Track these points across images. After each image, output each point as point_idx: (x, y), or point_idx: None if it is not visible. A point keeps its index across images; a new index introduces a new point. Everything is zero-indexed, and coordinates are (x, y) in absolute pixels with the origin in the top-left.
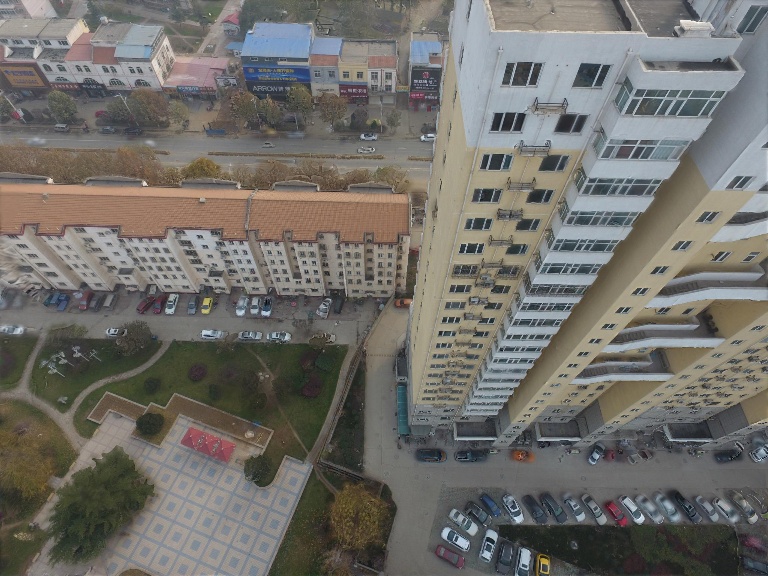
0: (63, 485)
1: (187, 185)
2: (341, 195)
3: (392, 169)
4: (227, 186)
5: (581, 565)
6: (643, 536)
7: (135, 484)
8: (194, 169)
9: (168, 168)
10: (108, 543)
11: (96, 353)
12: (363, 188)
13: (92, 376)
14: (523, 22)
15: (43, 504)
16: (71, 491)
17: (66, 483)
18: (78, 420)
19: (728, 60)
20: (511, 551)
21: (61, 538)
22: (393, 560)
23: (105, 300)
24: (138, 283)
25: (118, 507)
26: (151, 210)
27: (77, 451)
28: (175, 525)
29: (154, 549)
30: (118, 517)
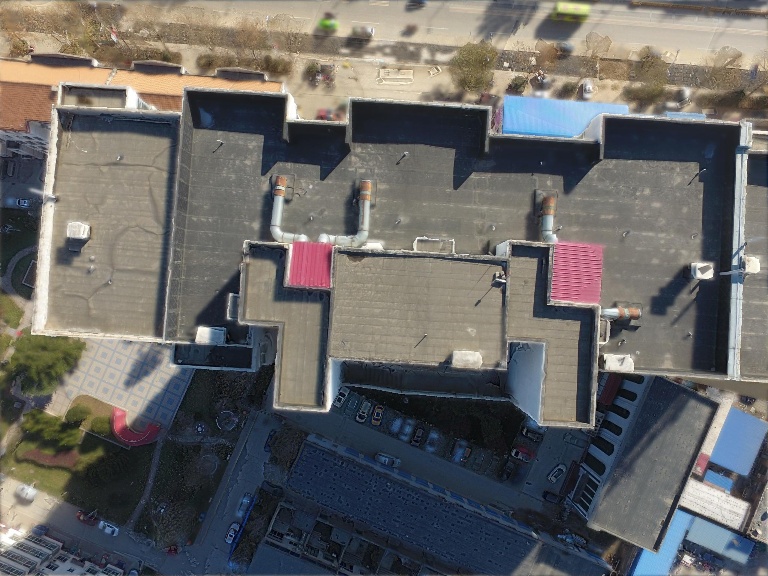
0: (15, 339)
1: (38, 59)
2: (207, 83)
3: (286, 18)
4: (82, 62)
5: (407, 414)
6: (459, 399)
7: (70, 341)
8: (51, 15)
9: (23, 9)
10: (62, 377)
11: (11, 227)
12: (232, 72)
13: (16, 245)
14: (79, 296)
15: (7, 347)
16: (14, 356)
17: (17, 338)
18: (15, 283)
19: (251, 351)
20: (356, 403)
21: (23, 378)
22: (271, 401)
23: (7, 167)
24: (32, 154)
25: (58, 361)
26: (6, 95)
27: (22, 309)
28: (109, 368)
29: (97, 383)
30: (61, 366)
